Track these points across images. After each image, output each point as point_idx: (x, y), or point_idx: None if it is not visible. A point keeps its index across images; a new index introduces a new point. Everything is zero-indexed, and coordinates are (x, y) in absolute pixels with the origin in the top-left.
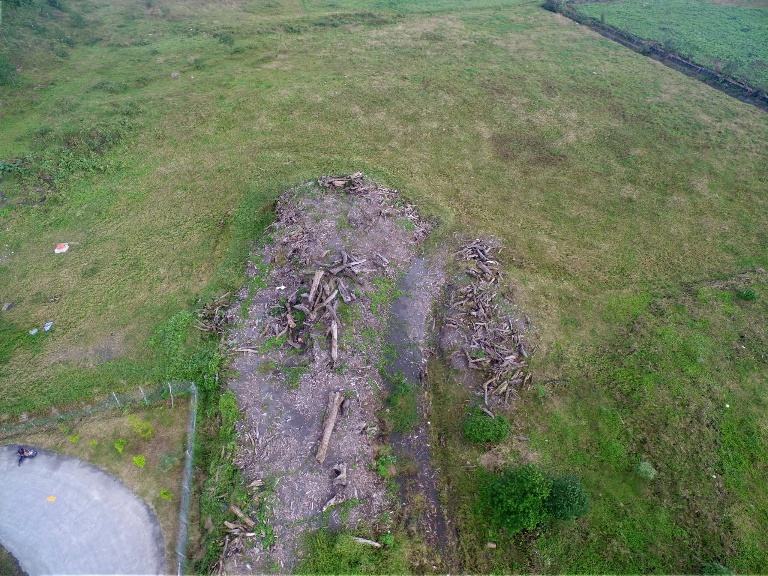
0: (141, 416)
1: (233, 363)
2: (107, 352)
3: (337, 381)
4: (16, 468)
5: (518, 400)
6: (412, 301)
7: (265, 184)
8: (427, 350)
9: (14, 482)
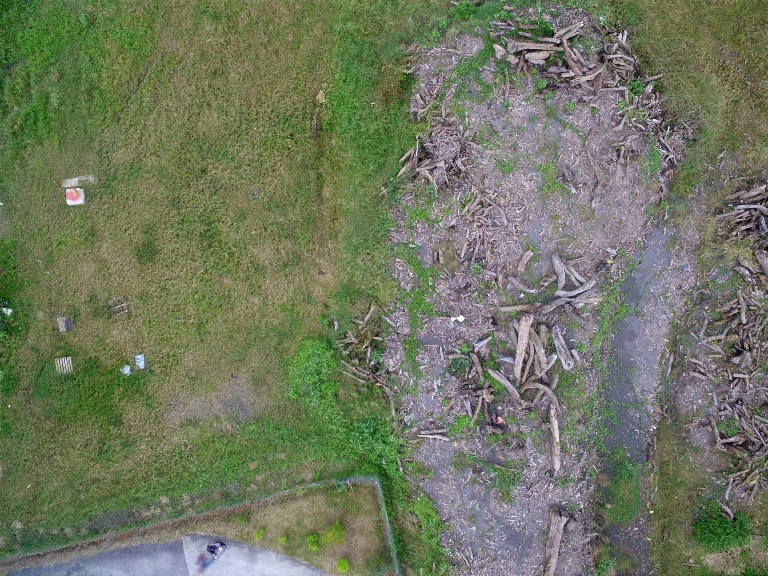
0: (319, 500)
1: (419, 455)
2: (239, 405)
3: (559, 494)
4: (213, 561)
5: (766, 493)
6: (643, 325)
7: (368, 5)
8: (658, 412)
9: (219, 575)
